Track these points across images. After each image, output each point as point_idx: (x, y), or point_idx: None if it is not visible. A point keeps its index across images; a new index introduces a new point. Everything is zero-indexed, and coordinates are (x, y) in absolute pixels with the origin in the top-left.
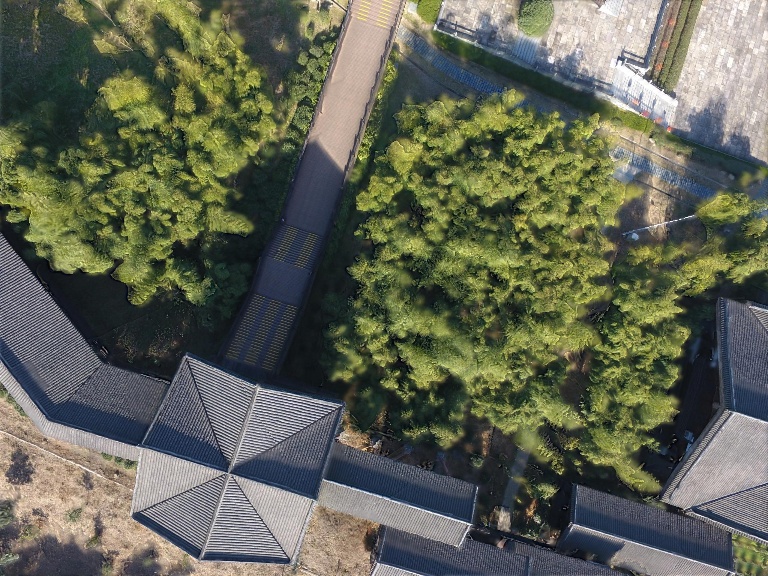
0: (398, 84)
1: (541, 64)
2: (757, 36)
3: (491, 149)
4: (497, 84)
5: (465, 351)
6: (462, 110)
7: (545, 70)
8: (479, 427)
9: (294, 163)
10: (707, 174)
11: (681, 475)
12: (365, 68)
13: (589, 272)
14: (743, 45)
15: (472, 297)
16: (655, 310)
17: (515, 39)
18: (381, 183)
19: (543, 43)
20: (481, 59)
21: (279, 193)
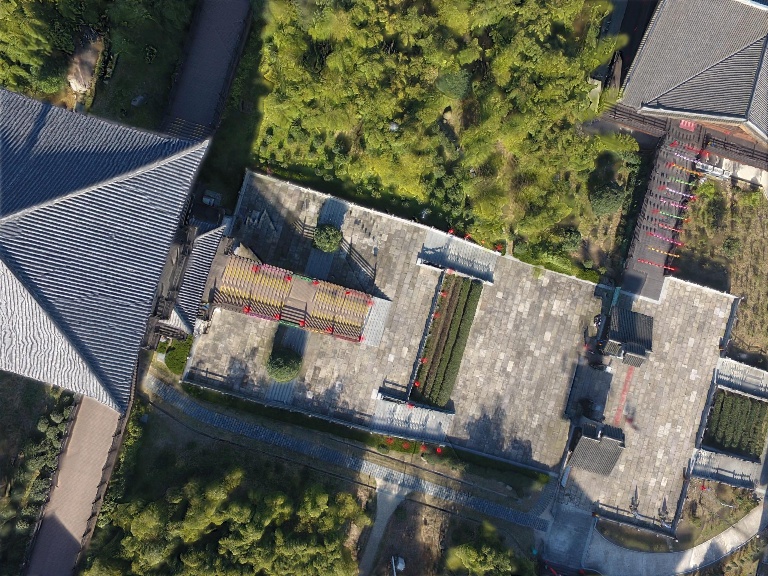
0: (148, 435)
1: (299, 400)
2: (538, 337)
3: (209, 546)
4: (254, 423)
5: None
6: (180, 506)
7: (304, 406)
8: None
9: (30, 539)
10: (484, 485)
11: None
12: (101, 439)
13: None
14: (523, 347)
15: None
16: None
17: (268, 382)
18: None
19: (301, 378)
20: (233, 405)
21: (12, 574)
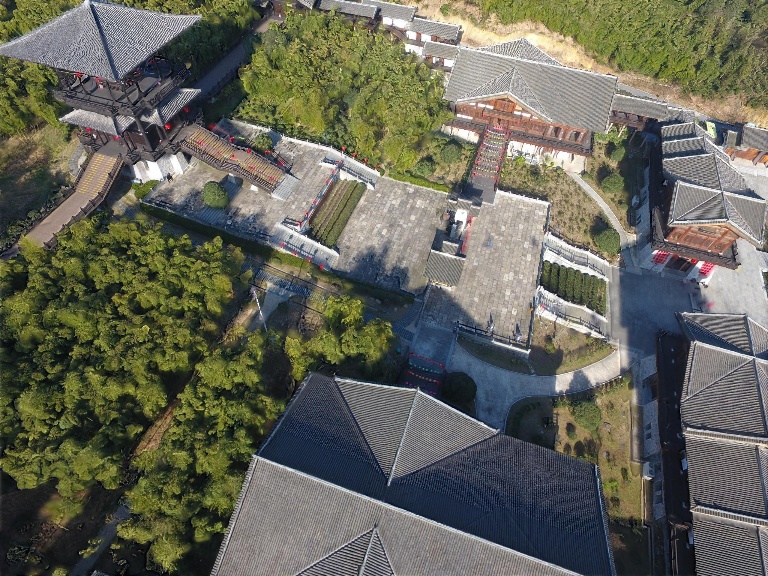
0: None
1: (221, 224)
2: (406, 218)
3: (120, 253)
4: None
5: (6, 392)
6: None
7: None
8: (43, 515)
9: None
10: None
11: (220, 556)
12: (70, 217)
13: (174, 340)
14: (395, 222)
15: (42, 349)
16: (233, 376)
17: (202, 209)
18: (3, 263)
19: (226, 213)
20: (171, 219)
21: None
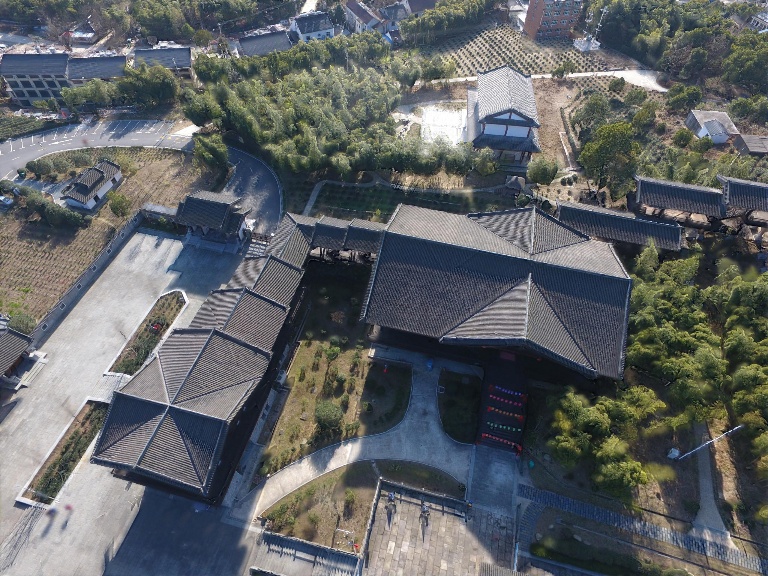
0: None
1: None
2: None
3: None
4: None
5: None
6: None
7: None
8: None
9: None
10: (605, 540)
11: None
12: None
13: None
14: None
15: None
16: (688, 361)
17: None
18: None
19: None
20: None
21: None
